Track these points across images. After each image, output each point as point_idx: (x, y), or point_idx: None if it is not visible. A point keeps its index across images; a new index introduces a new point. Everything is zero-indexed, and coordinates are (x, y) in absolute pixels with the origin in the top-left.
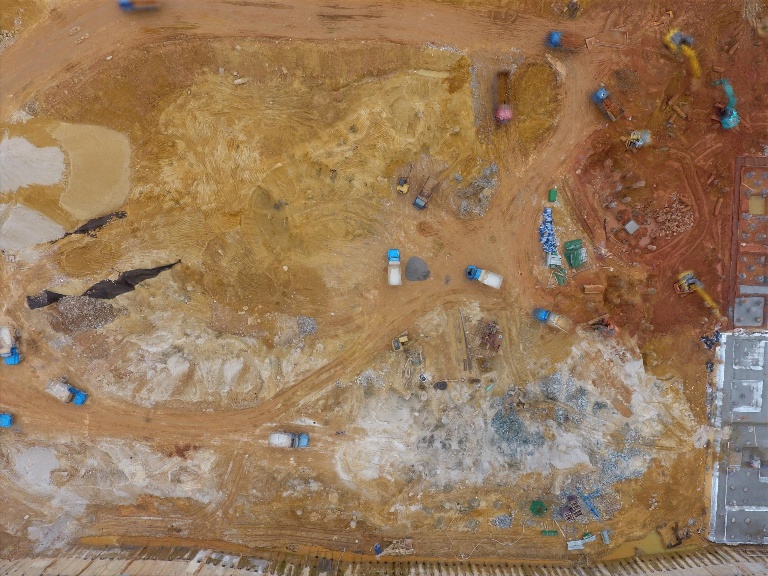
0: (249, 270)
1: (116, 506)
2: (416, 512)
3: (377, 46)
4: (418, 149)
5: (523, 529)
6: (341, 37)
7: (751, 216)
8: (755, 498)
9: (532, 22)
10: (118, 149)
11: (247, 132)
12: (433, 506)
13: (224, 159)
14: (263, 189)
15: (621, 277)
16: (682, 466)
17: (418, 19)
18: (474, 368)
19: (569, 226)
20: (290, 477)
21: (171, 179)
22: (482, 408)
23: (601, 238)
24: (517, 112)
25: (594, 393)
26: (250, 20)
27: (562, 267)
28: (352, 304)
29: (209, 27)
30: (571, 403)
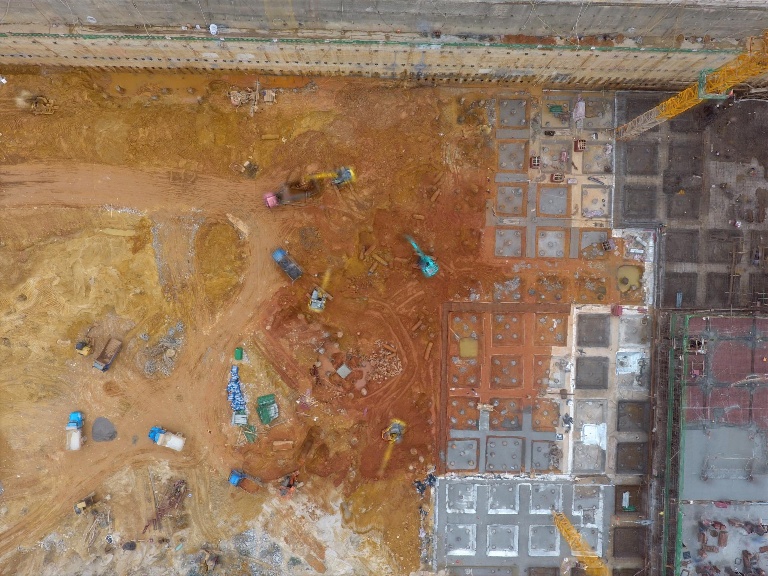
0: None
1: None
2: None
3: (51, 211)
4: (99, 311)
5: None
6: (13, 203)
7: None
8: None
9: (212, 182)
10: None
11: None
12: None
13: None
14: None
15: (322, 428)
16: None
17: (94, 182)
18: (164, 527)
19: (261, 381)
20: None
21: None
22: (174, 567)
23: (306, 387)
24: (202, 270)
25: (286, 550)
26: None
27: (251, 424)
28: (38, 466)
29: None
30: (265, 559)
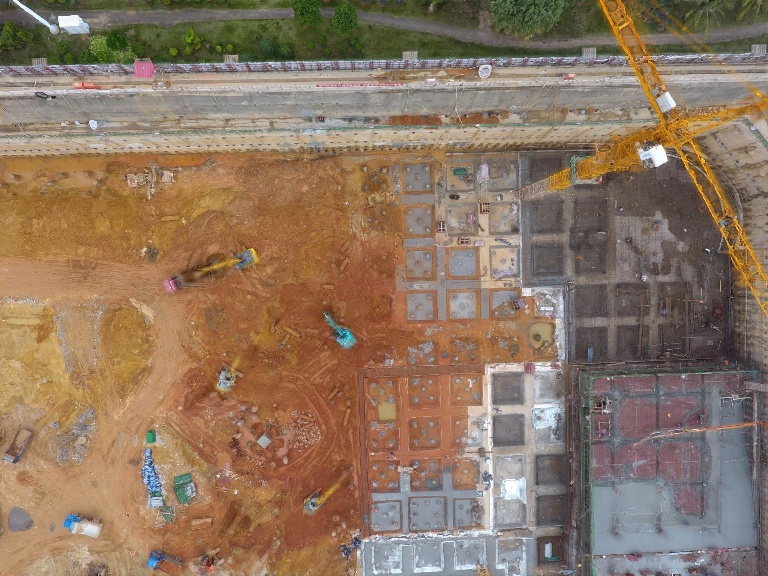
0: None
1: None
2: None
3: None
4: (7, 403)
5: None
6: None
7: None
8: None
9: (112, 268)
10: None
11: None
12: None
13: None
14: None
15: (243, 501)
16: None
17: None
18: None
19: (177, 461)
20: None
21: None
22: None
23: (225, 461)
24: (109, 356)
25: None
26: None
27: (169, 505)
28: None
29: None
30: None
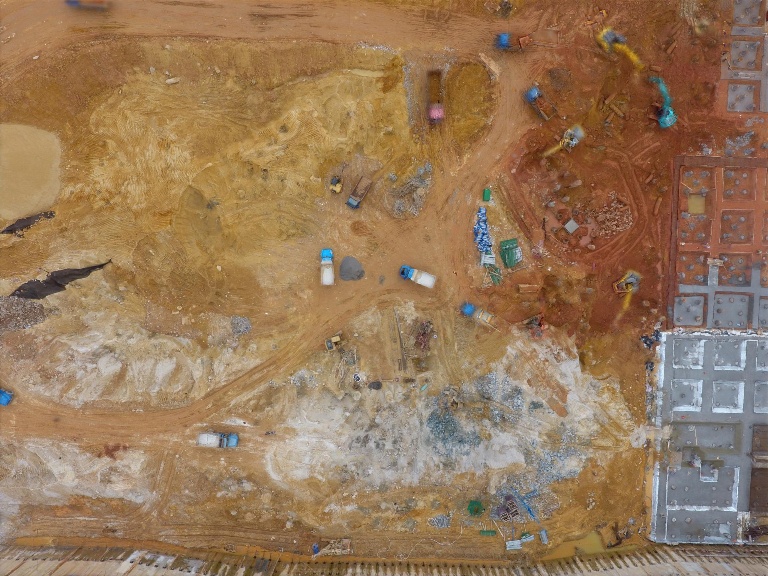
0: (182, 270)
1: (50, 507)
2: (352, 512)
3: (309, 45)
4: (351, 148)
5: (461, 529)
6: (272, 36)
7: (690, 215)
8: (696, 497)
9: (465, 21)
10: (47, 149)
11: (179, 132)
12: (370, 506)
13: (155, 159)
14: (195, 189)
15: (558, 276)
16: (618, 466)
17: (350, 18)
18: (409, 368)
19: (504, 225)
20: (223, 477)
21: (101, 179)
22: (417, 408)
23: (539, 237)
24: (451, 111)
25: (529, 393)
26: (180, 19)
27: (497, 266)
28: (286, 304)
29: (138, 26)
30: (507, 403)
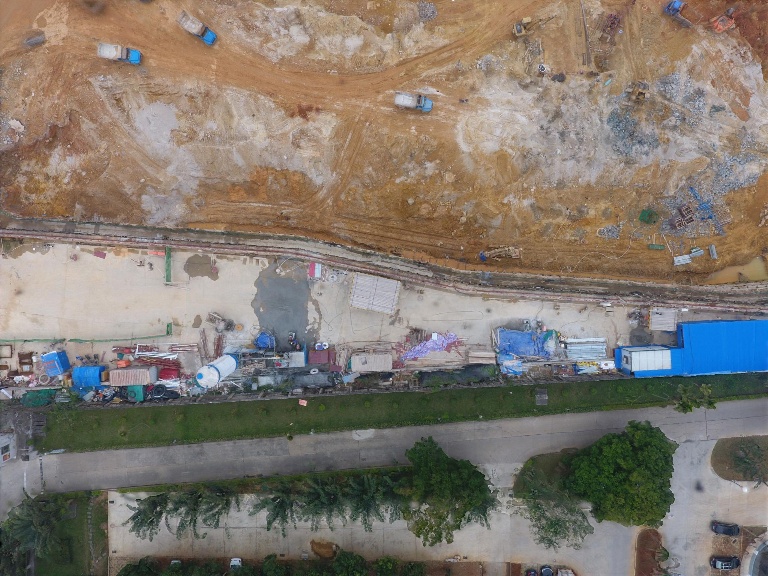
0: None
1: (227, 188)
2: (526, 211)
3: None
4: None
5: (630, 241)
6: None
7: None
8: None
9: None
10: None
11: None
12: (543, 208)
13: None
14: None
15: None
16: None
17: None
18: (593, 63)
19: None
20: (406, 159)
21: None
22: (599, 104)
23: None
24: None
25: (713, 93)
26: None
27: None
28: None
29: None
30: (688, 105)
